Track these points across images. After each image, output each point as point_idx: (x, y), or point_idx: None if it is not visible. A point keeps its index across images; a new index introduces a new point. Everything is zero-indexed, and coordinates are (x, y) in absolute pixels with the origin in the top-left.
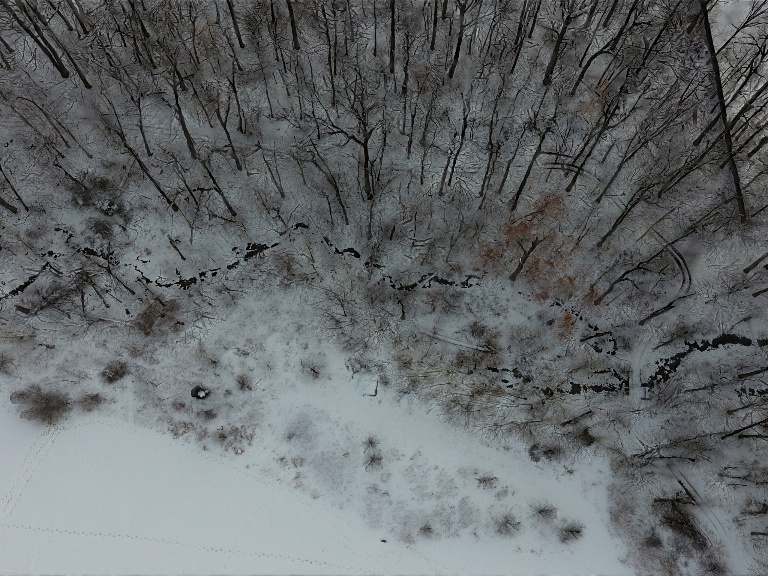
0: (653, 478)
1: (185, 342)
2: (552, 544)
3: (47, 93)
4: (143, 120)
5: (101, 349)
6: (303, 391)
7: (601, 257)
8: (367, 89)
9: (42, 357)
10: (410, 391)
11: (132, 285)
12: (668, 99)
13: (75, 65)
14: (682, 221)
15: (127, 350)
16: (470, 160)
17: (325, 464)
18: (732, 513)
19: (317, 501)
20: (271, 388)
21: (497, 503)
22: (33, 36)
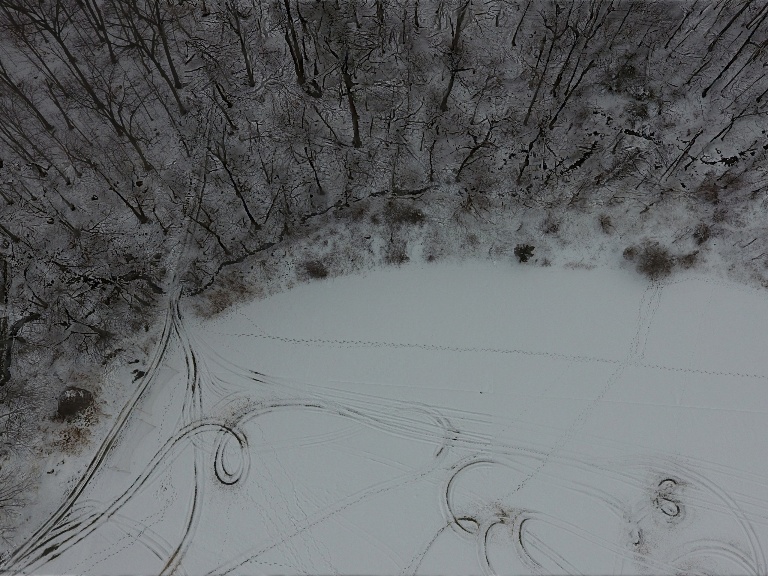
0: None
1: (765, 208)
2: None
3: None
4: (650, 16)
5: (686, 214)
6: None
7: None
8: None
9: (637, 219)
10: None
11: None
12: None
13: None
14: None
15: (712, 215)
16: None
17: None
18: None
19: None
20: None
21: None
22: None
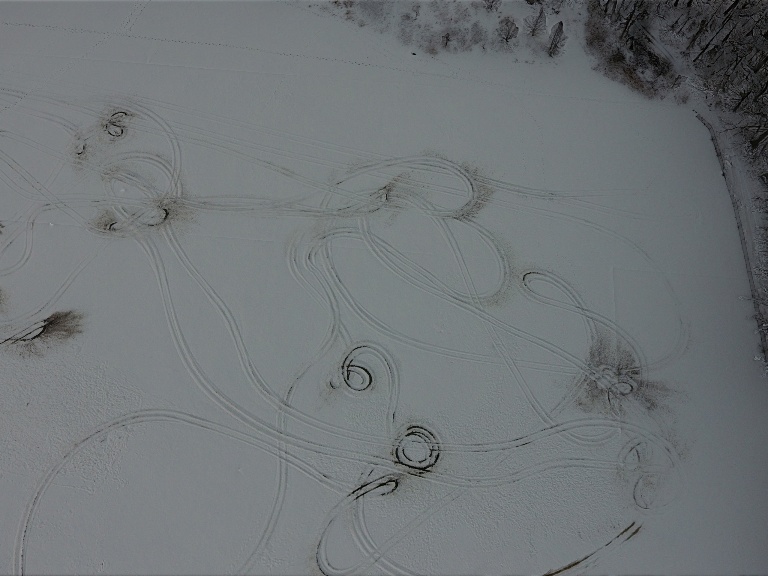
0: None
1: None
2: (542, 58)
3: None
4: None
5: None
6: None
7: None
8: None
9: None
10: None
11: None
12: None
13: None
14: None
15: None
16: None
17: (369, 3)
18: (680, 49)
19: (363, 28)
20: None
21: None
22: None
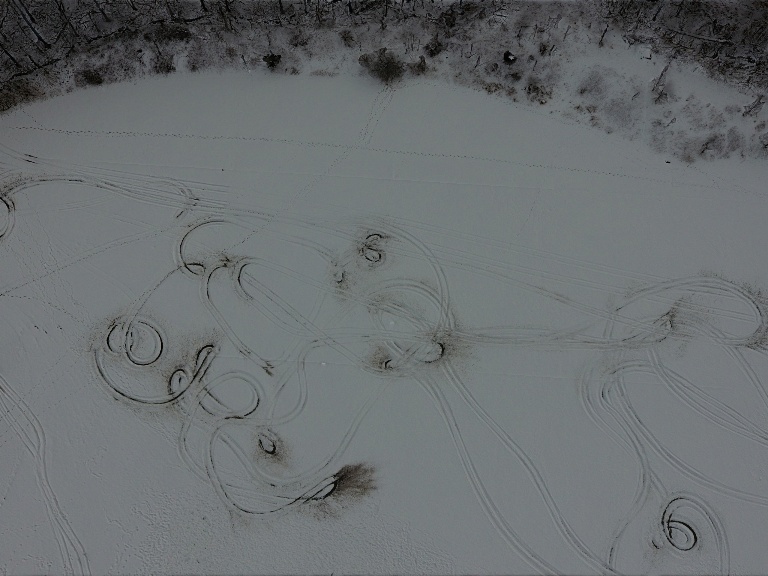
0: None
1: (490, 25)
2: None
3: None
4: None
5: (421, 31)
6: (592, 56)
7: None
8: None
9: (376, 35)
10: (678, 56)
11: None
12: None
13: None
14: None
15: (443, 31)
16: None
17: (615, 108)
18: None
19: (611, 135)
20: (566, 53)
21: (757, 133)
22: None
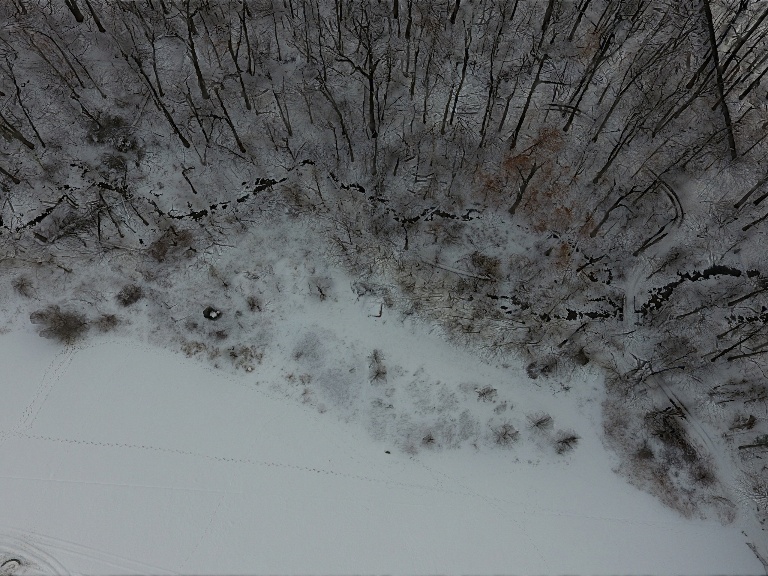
0: (646, 396)
1: (197, 267)
2: (549, 455)
3: (62, 36)
4: None
5: (116, 274)
6: (311, 312)
7: (597, 193)
8: (372, 33)
9: (60, 280)
10: (413, 312)
11: (145, 216)
12: (661, 28)
13: (90, 7)
14: (675, 159)
15: (141, 274)
16: (471, 101)
17: (332, 380)
18: (721, 429)
19: (324, 415)
20: (280, 309)
21: (496, 417)
22: None
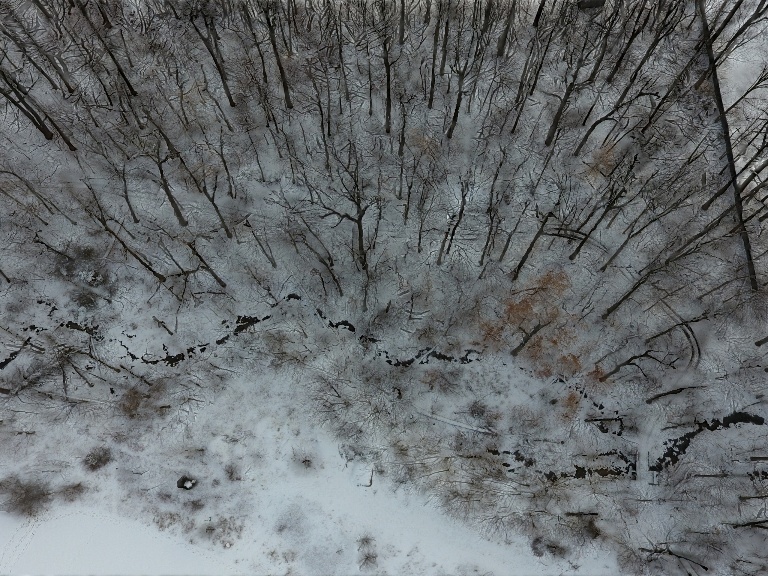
0: (662, 572)
1: (171, 427)
2: None
3: (30, 156)
4: (130, 184)
5: (84, 434)
6: (294, 481)
7: (606, 330)
8: (362, 152)
9: (22, 444)
10: (407, 481)
11: (117, 362)
12: (677, 181)
13: (58, 129)
14: (691, 290)
15: (111, 436)
16: (469, 226)
17: (317, 560)
18: None
19: None
20: (261, 478)
21: None
22: (14, 102)
